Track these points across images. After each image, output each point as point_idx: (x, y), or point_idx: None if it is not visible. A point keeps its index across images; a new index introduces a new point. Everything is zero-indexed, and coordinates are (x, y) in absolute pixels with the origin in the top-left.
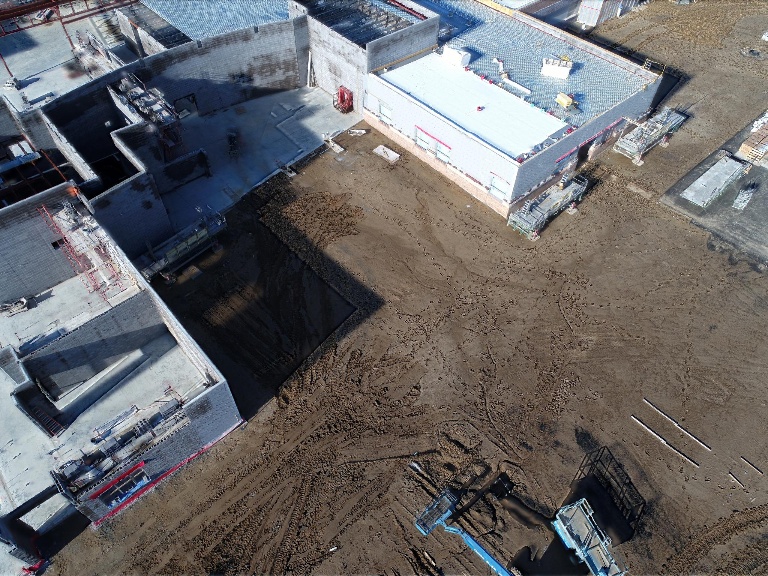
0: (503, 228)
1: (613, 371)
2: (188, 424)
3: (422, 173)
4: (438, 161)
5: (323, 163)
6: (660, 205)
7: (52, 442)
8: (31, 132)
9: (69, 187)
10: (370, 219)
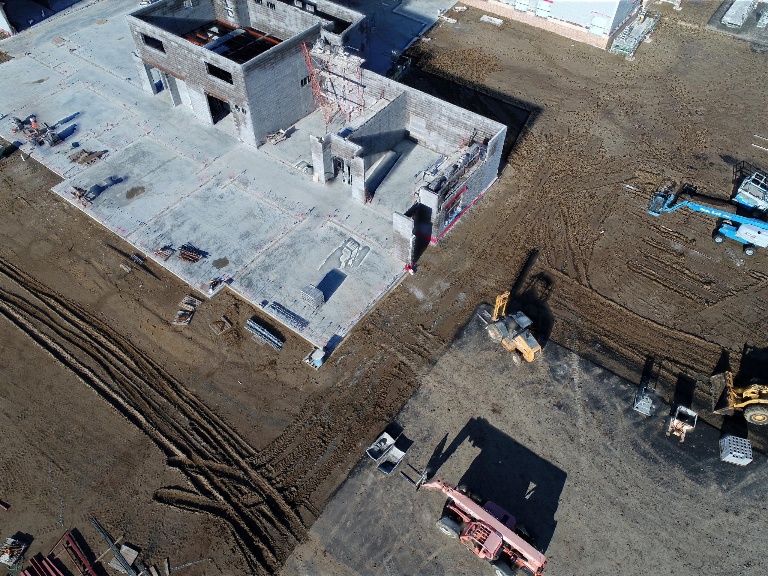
0: (606, 55)
1: (726, 123)
2: (485, 162)
3: (526, 30)
4: (538, 18)
5: (446, 31)
6: (707, 31)
7: (368, 206)
8: (238, 9)
9: (318, 28)
10: (505, 61)
